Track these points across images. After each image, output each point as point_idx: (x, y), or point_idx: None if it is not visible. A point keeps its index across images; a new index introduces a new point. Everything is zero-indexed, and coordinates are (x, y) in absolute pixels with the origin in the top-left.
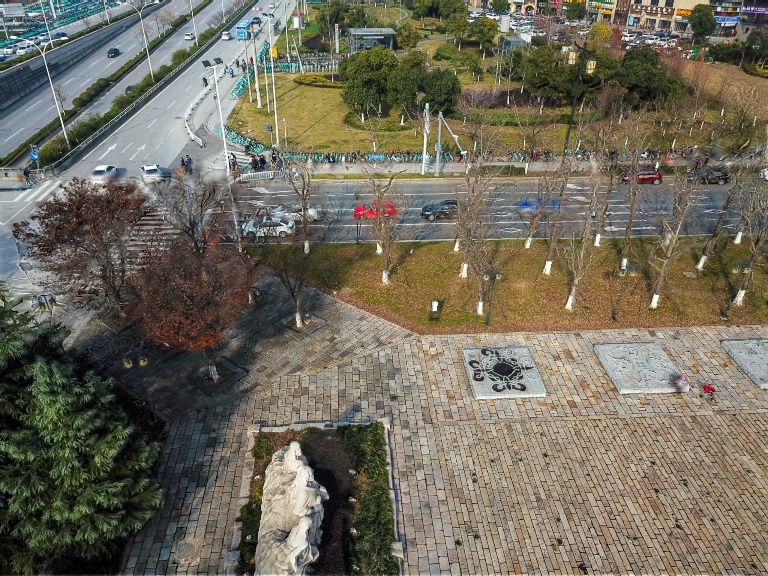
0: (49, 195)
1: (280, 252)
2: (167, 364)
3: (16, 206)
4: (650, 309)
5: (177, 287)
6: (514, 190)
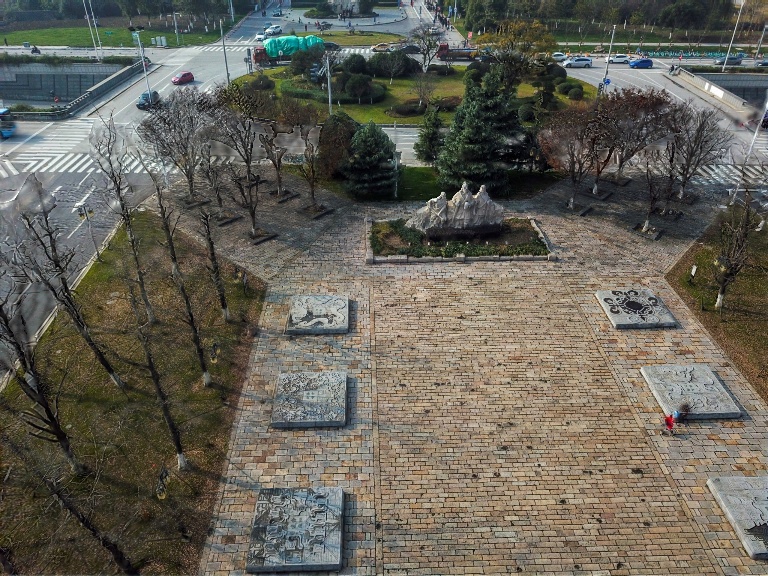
0: None
1: None
2: (577, 195)
3: None
4: None
5: None
6: None
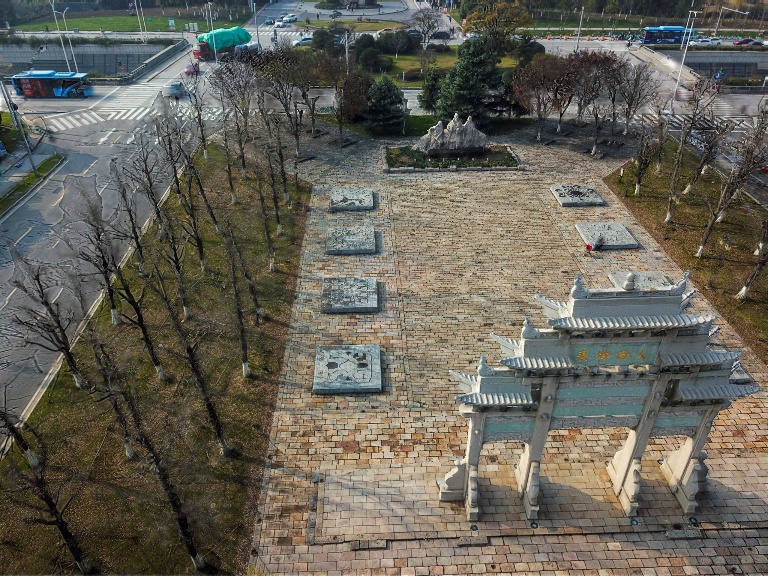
0: (689, 95)
1: None
2: None
3: (666, 92)
4: (693, 254)
5: None
6: None
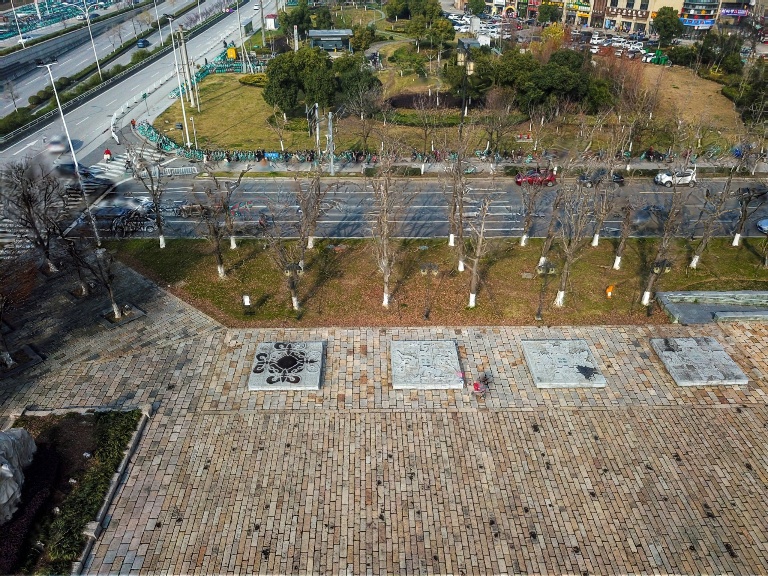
0: None
1: (136, 246)
2: None
3: None
4: (467, 308)
5: None
6: (402, 190)
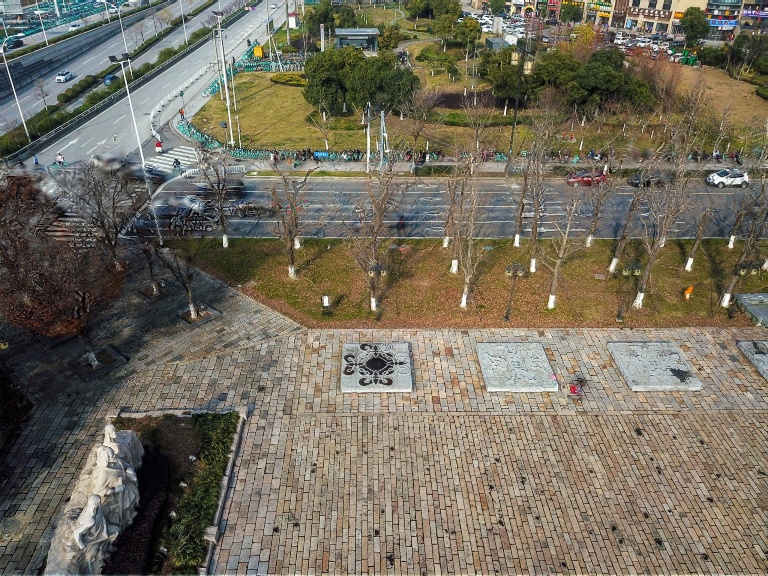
0: None
1: (199, 245)
2: (54, 350)
3: None
4: (546, 309)
5: (26, 273)
6: None
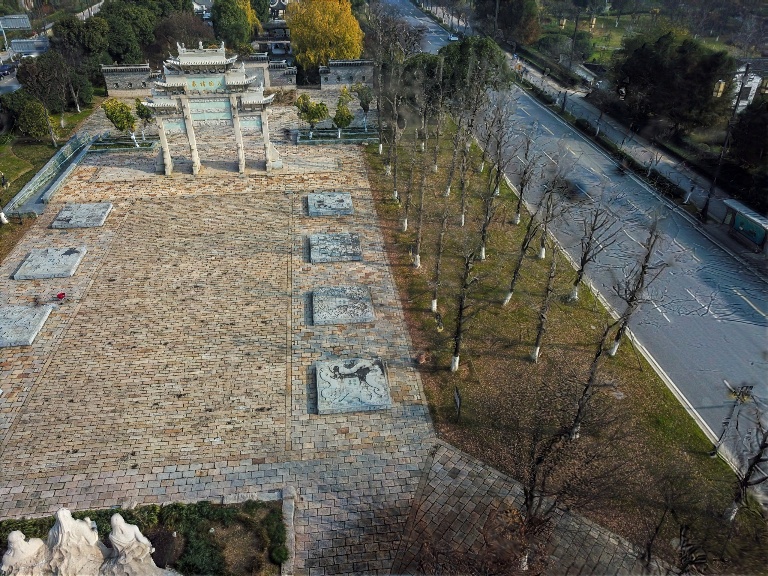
0: None
1: None
2: None
3: None
4: None
5: None
6: None
